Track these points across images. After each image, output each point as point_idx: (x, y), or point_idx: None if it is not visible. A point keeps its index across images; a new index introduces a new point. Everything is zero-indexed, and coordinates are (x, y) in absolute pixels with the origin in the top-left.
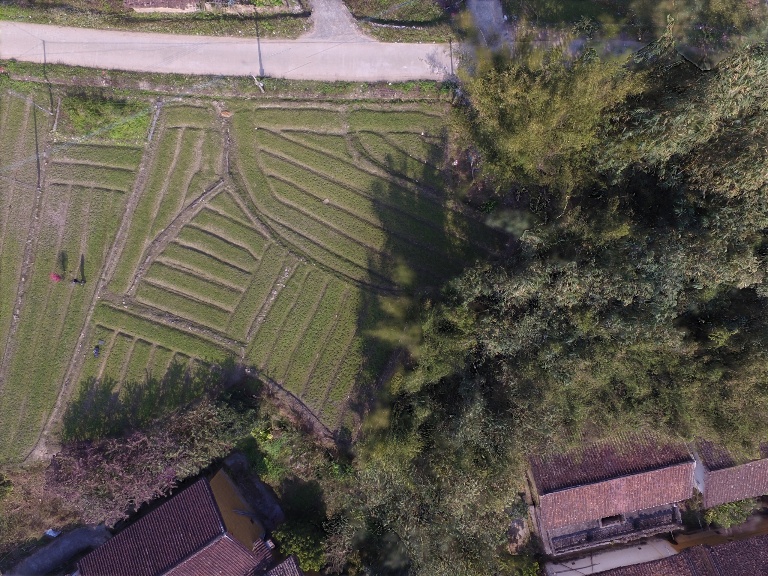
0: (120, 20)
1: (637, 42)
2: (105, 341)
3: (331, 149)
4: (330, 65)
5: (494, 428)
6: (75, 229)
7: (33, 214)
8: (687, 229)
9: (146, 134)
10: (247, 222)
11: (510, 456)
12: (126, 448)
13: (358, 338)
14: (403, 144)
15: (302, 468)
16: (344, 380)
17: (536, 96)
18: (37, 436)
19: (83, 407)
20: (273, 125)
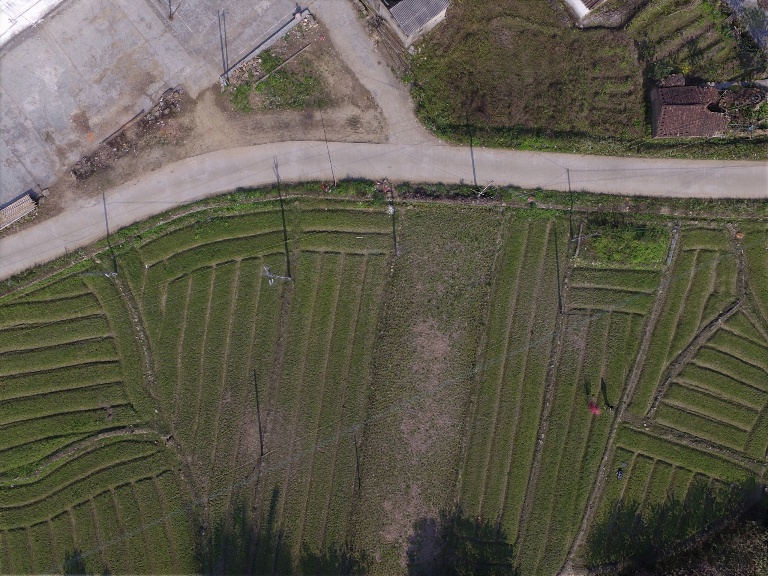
0: (641, 147)
1: None
2: (627, 463)
3: None
4: None
5: None
6: (596, 353)
7: (556, 339)
8: None
9: (664, 258)
10: (764, 342)
11: None
12: None
13: None
14: None
15: None
16: None
17: None
18: (563, 559)
19: (607, 530)
20: None
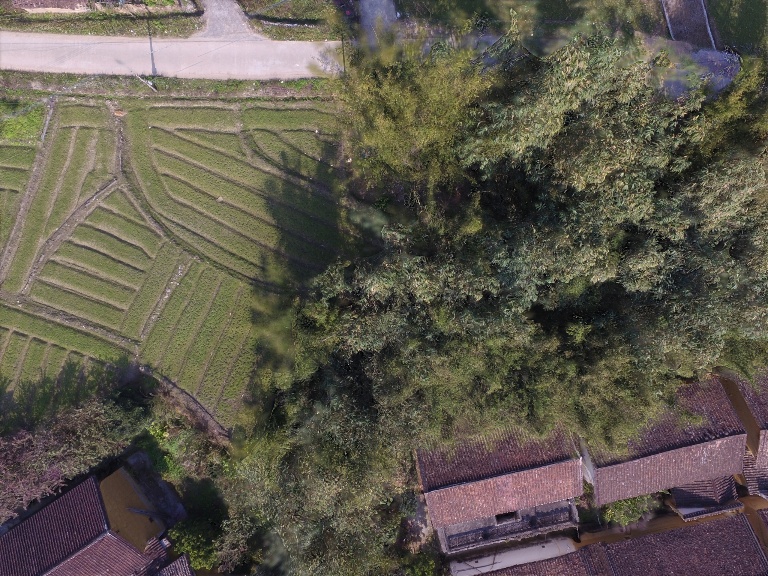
0: (12, 21)
1: (529, 38)
2: None
3: (224, 147)
4: (222, 64)
5: (355, 424)
6: None
7: None
8: (546, 224)
9: (39, 134)
10: (140, 220)
11: (370, 452)
12: (12, 446)
13: (252, 336)
14: (297, 142)
15: (193, 466)
16: (238, 378)
17: (389, 91)
18: None
19: None
20: (166, 124)
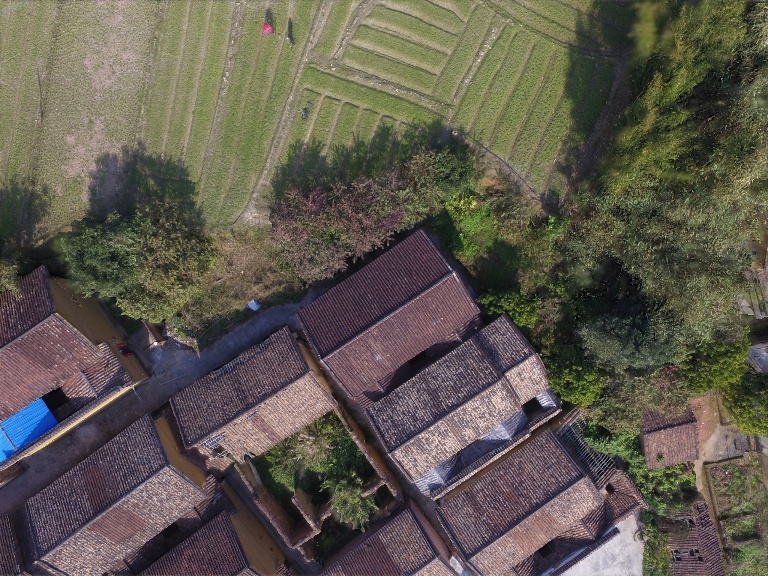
0: None
1: None
2: (313, 104)
3: None
4: None
5: (765, 117)
6: None
7: None
8: None
9: None
10: None
11: None
12: (351, 191)
13: (565, 99)
14: None
15: (515, 224)
16: (552, 142)
17: None
18: (246, 199)
19: (291, 170)
20: None
